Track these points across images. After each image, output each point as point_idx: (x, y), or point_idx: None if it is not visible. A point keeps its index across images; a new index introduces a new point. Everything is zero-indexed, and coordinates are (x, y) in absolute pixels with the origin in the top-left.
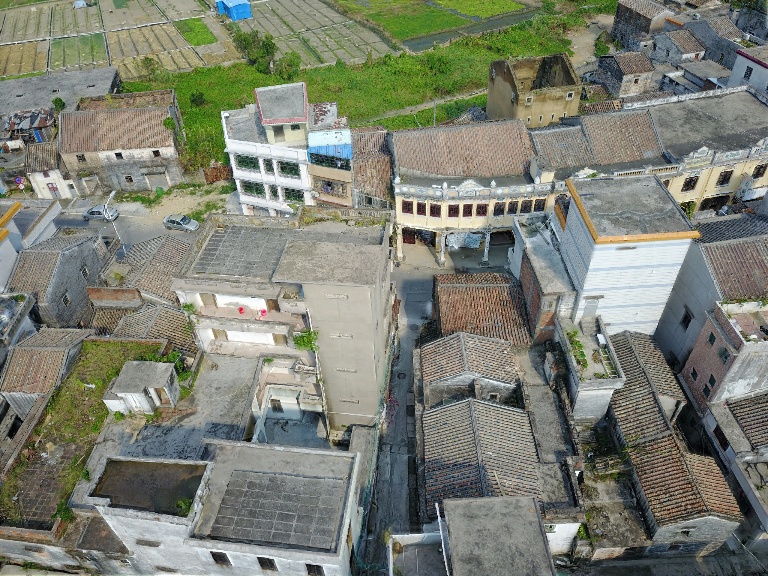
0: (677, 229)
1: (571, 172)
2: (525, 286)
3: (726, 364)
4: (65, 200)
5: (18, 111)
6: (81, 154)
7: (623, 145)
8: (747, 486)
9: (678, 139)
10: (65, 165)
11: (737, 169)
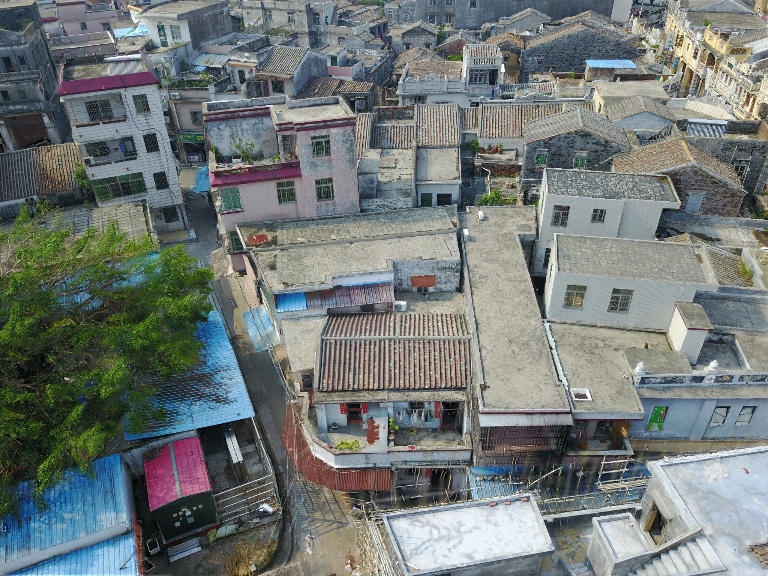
0: None
1: (684, 2)
2: None
3: None
4: None
5: None
6: None
7: None
8: None
9: None
10: None
11: None
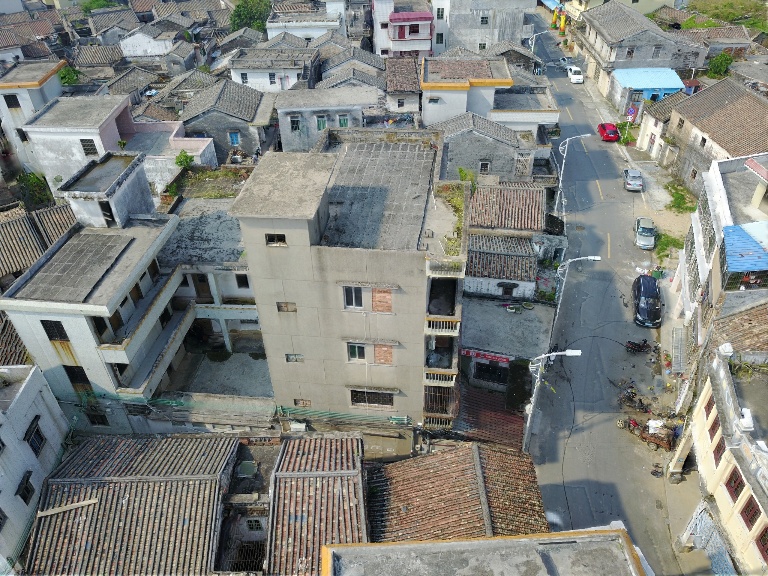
0: None
1: None
2: None
3: None
4: (648, 157)
5: (762, 81)
6: (683, 119)
7: None
8: None
9: None
10: (669, 123)
11: None
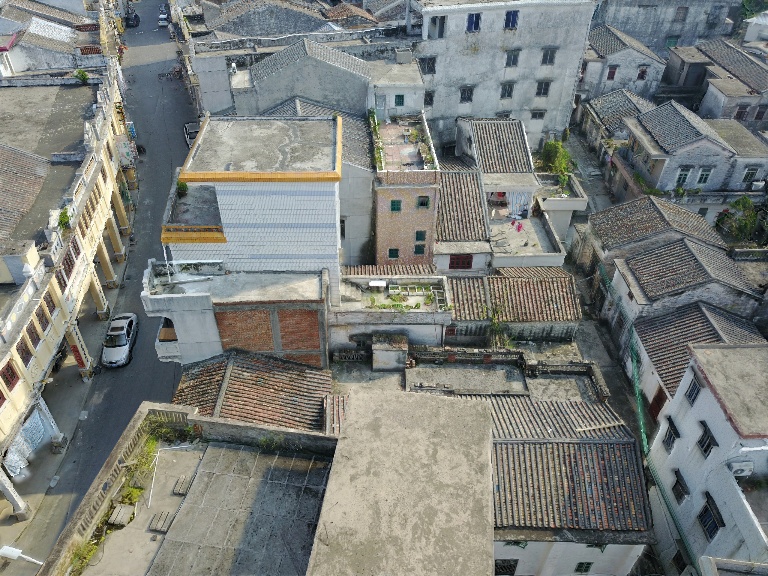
0: (326, 127)
1: None
2: (252, 341)
3: (430, 206)
4: None
5: None
6: None
7: (8, 180)
8: (519, 260)
9: (25, 147)
10: None
11: (108, 136)
